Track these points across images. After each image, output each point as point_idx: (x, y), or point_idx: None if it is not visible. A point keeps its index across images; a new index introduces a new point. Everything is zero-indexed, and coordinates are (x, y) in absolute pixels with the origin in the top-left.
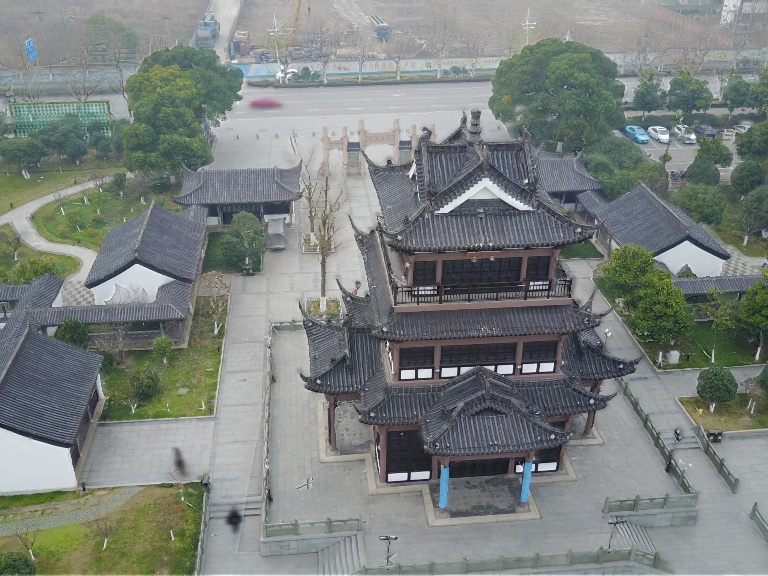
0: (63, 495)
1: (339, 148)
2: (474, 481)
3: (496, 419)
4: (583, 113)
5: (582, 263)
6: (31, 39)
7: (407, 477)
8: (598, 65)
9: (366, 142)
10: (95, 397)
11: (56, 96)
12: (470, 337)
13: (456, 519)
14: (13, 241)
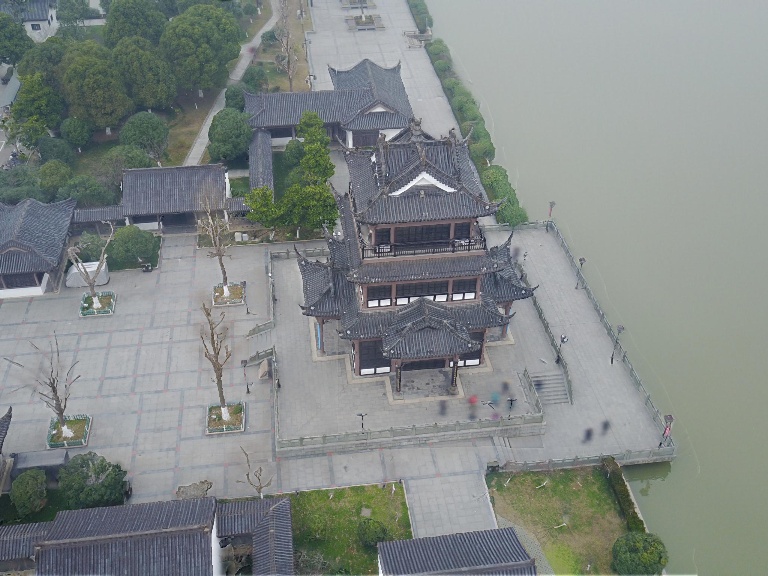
0: None
1: None
2: None
3: None
4: None
5: (168, 250)
6: None
7: None
8: None
9: None
10: None
11: None
12: None
13: (508, 332)
14: None
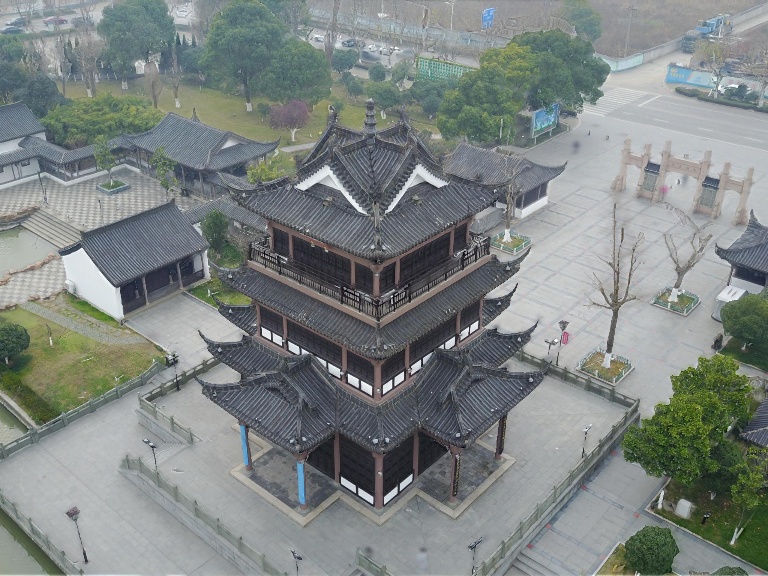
0: (112, 321)
1: (638, 165)
2: (305, 467)
3: (281, 403)
4: None
5: (756, 375)
6: (493, 8)
7: None
8: None
9: (668, 167)
10: (200, 274)
11: (465, 59)
12: (289, 316)
13: (250, 481)
14: (301, 156)
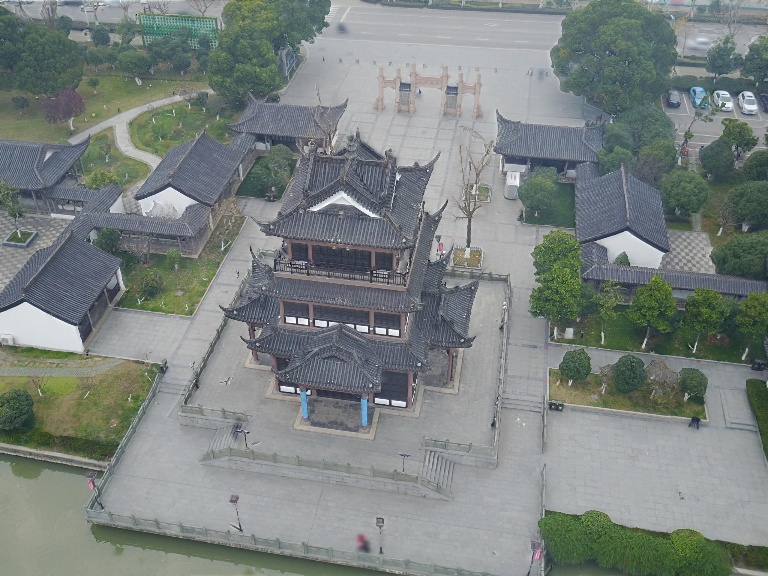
0: (74, 356)
1: (392, 87)
2: (342, 403)
3: (340, 365)
4: (619, 80)
5: None
6: None
7: (294, 390)
8: (652, 30)
9: (417, 84)
10: (117, 288)
11: (181, 6)
12: (327, 303)
13: (313, 428)
14: (105, 147)
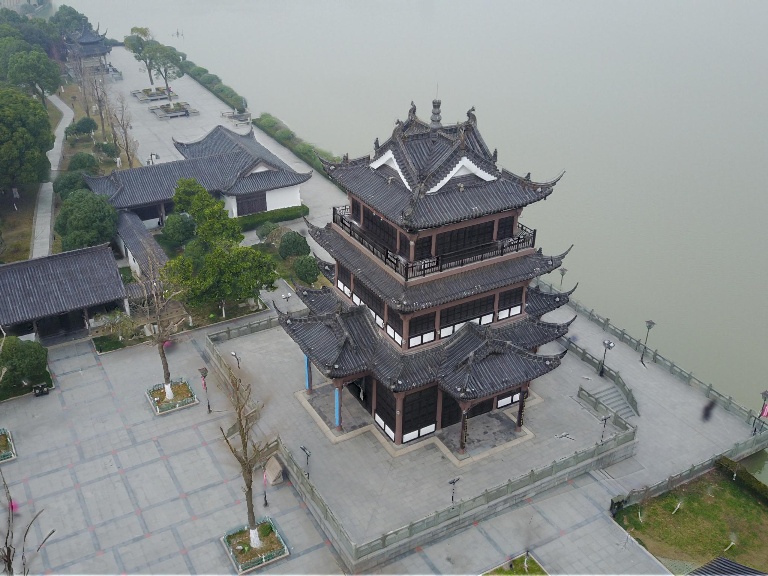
0: None
1: None
2: None
3: None
4: None
5: (58, 364)
6: None
7: None
8: None
9: None
10: None
11: None
12: None
13: None
14: None
